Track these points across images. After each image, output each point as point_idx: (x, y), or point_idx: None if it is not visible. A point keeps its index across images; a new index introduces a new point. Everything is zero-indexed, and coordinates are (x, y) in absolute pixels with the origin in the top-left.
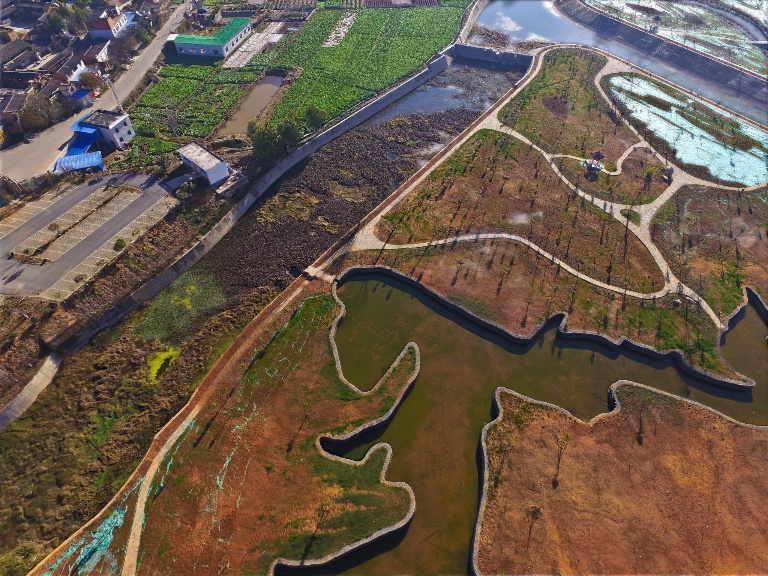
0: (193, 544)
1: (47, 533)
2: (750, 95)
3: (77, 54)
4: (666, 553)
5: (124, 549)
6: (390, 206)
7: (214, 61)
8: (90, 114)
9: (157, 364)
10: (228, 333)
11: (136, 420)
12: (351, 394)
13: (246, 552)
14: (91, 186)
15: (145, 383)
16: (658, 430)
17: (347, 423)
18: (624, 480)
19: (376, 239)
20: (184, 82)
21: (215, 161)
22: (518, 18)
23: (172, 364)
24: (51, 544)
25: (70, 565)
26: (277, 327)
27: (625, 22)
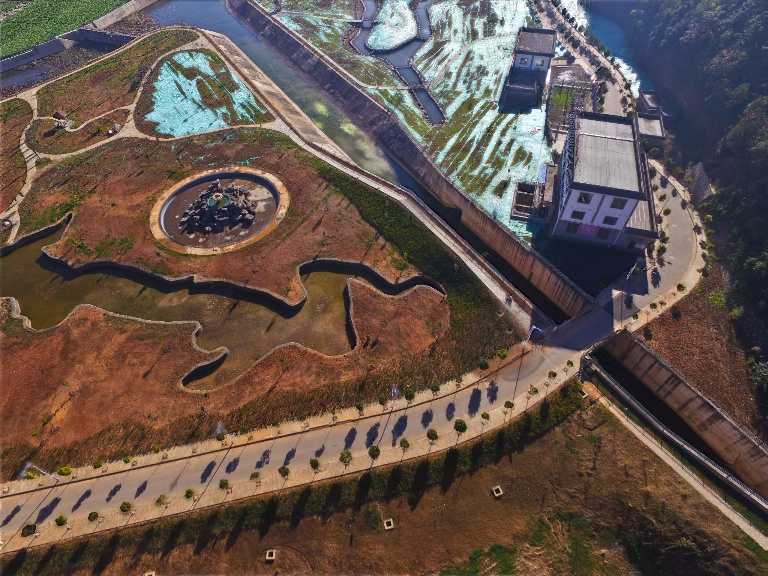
0: None
1: None
2: (299, 66)
3: None
4: None
5: None
6: None
7: None
8: None
9: None
10: None
11: None
12: None
13: None
14: None
15: None
16: None
17: None
18: None
19: None
20: None
21: None
22: (184, 6)
23: None
24: None
25: None
26: None
27: (258, 6)
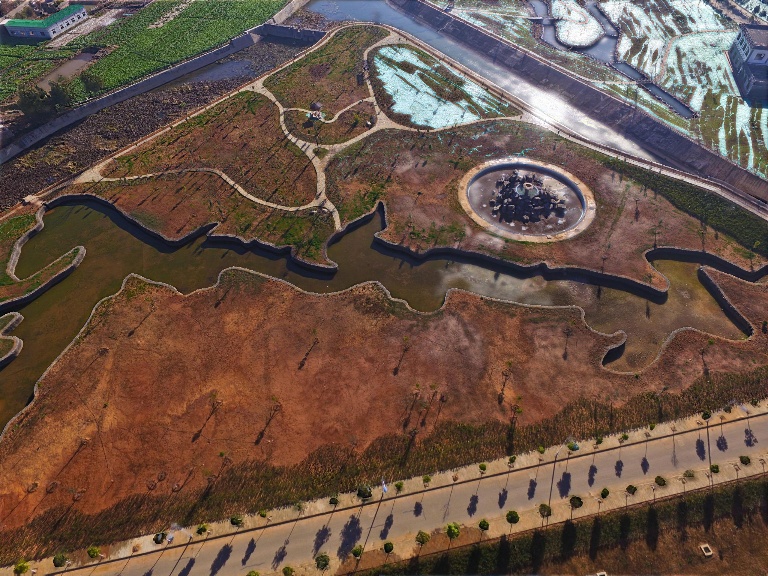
0: None
1: None
2: (502, 61)
3: None
4: (184, 372)
5: None
6: (126, 151)
7: (39, 41)
8: None
9: None
10: None
11: None
12: (8, 281)
13: None
14: None
15: None
16: (236, 298)
17: None
18: (185, 329)
19: (98, 175)
20: (2, 59)
21: None
22: (344, 2)
23: None
24: None
25: None
26: None
27: (428, 3)
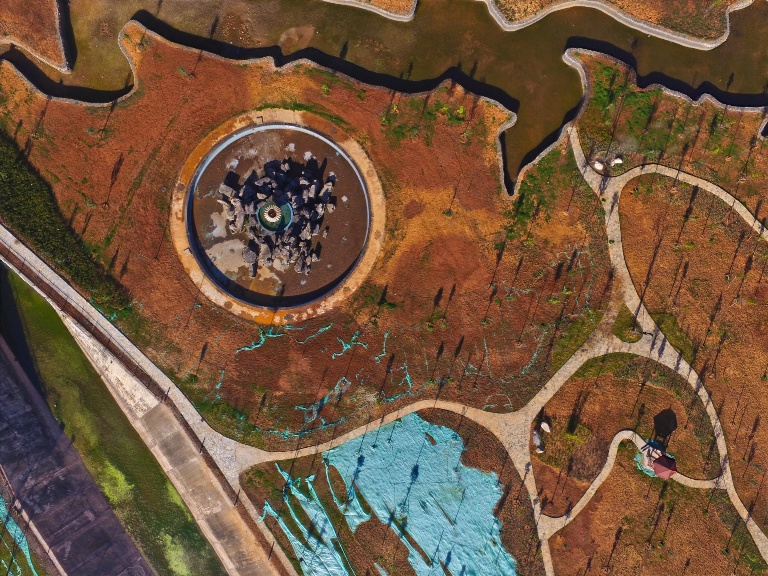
0: None
1: None
2: None
3: None
4: None
5: None
6: None
7: None
8: None
9: None
10: None
11: None
12: None
13: None
14: None
15: None
16: None
17: None
18: None
19: None
20: None
21: None
22: None
23: None
24: None
25: None
26: None
27: None
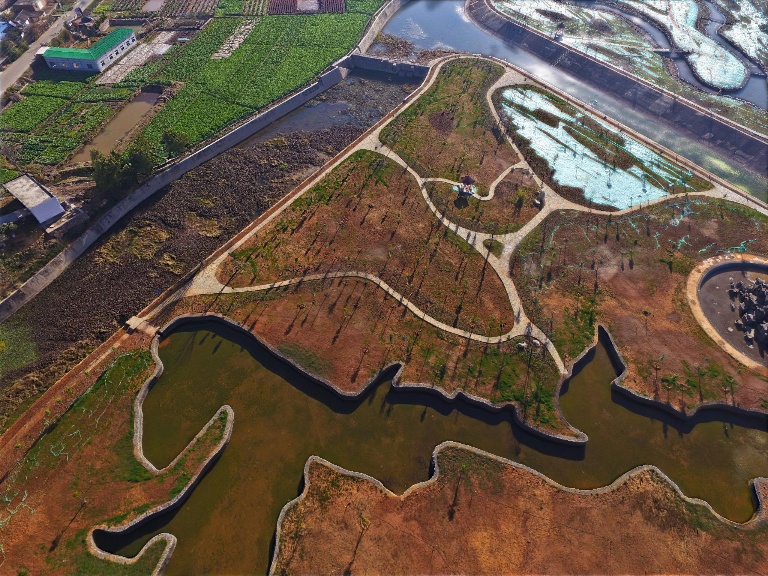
0: None
1: None
2: (645, 107)
3: None
4: None
5: None
6: (240, 242)
7: (87, 76)
8: None
9: None
10: (30, 399)
11: None
12: (142, 473)
13: None
14: None
15: None
16: (473, 501)
17: (128, 511)
18: (423, 566)
19: (216, 281)
20: (47, 101)
21: (44, 197)
22: (427, 25)
23: None
24: None
25: None
26: (78, 393)
27: (531, 29)
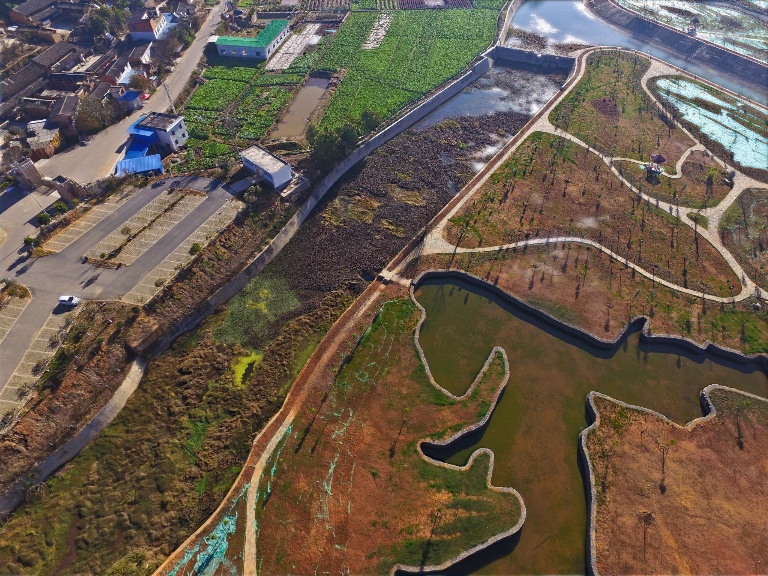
0: (310, 551)
1: (155, 540)
2: None
3: (121, 56)
4: None
5: (241, 556)
6: (455, 209)
7: (257, 63)
8: (145, 117)
9: (241, 369)
10: (308, 337)
11: (229, 425)
12: (445, 399)
13: (364, 558)
14: (155, 189)
15: (232, 388)
16: (757, 435)
17: (446, 428)
18: (731, 485)
19: (446, 243)
20: (230, 84)
21: (279, 164)
22: (552, 20)
23: (256, 369)
24: (161, 551)
25: (189, 572)
26: (360, 331)
27: (662, 24)
